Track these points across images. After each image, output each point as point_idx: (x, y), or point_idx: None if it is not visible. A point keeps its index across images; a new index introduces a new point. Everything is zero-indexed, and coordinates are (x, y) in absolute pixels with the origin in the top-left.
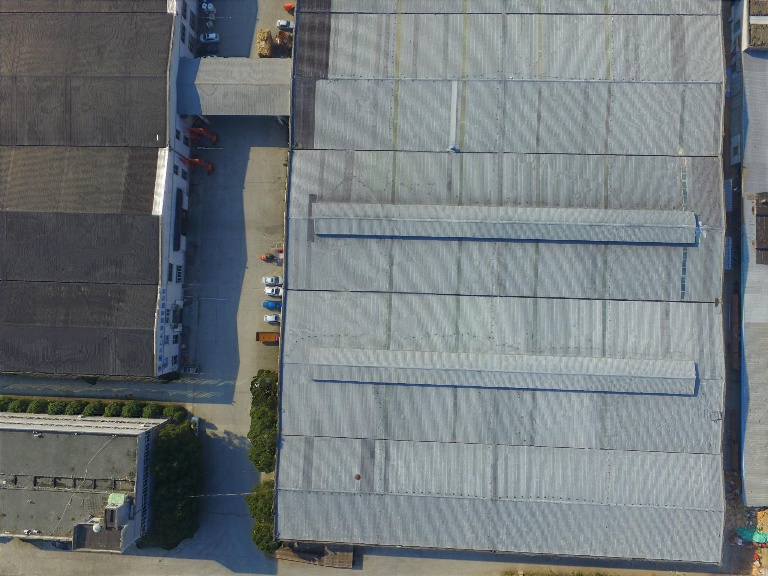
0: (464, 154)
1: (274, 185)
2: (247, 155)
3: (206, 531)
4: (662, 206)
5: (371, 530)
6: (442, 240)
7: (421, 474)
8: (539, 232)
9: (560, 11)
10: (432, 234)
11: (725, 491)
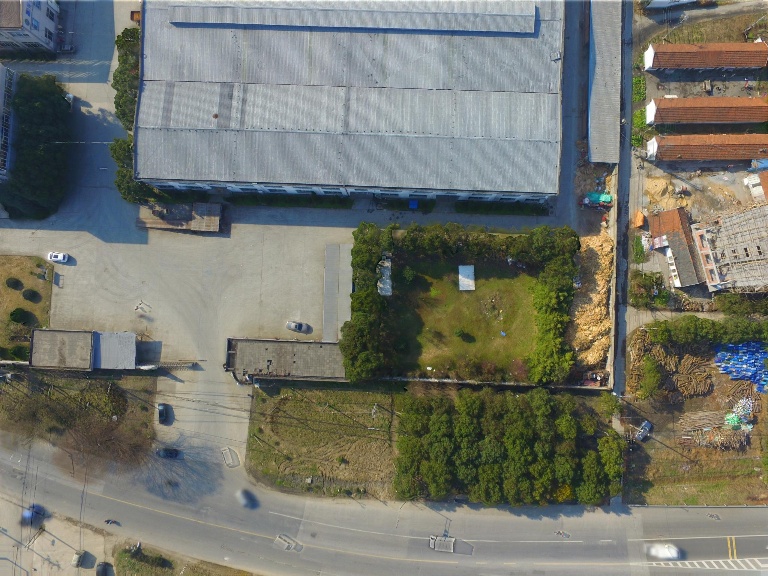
0: None
1: None
2: None
3: (79, 204)
4: None
5: (227, 167)
6: None
7: (276, 113)
8: None
9: None
10: None
11: (576, 160)
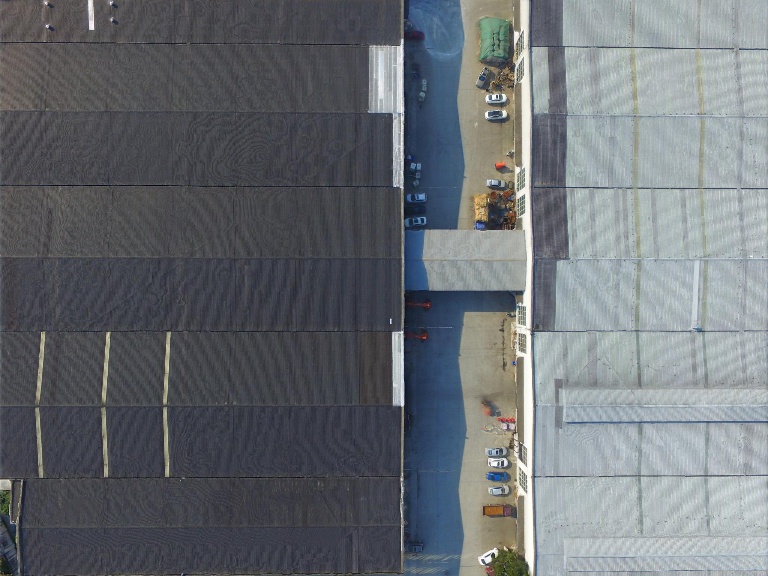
0: (706, 333)
1: (490, 351)
2: (461, 320)
3: None
4: None
5: None
6: (690, 423)
7: None
8: None
9: None
10: (683, 419)
11: None
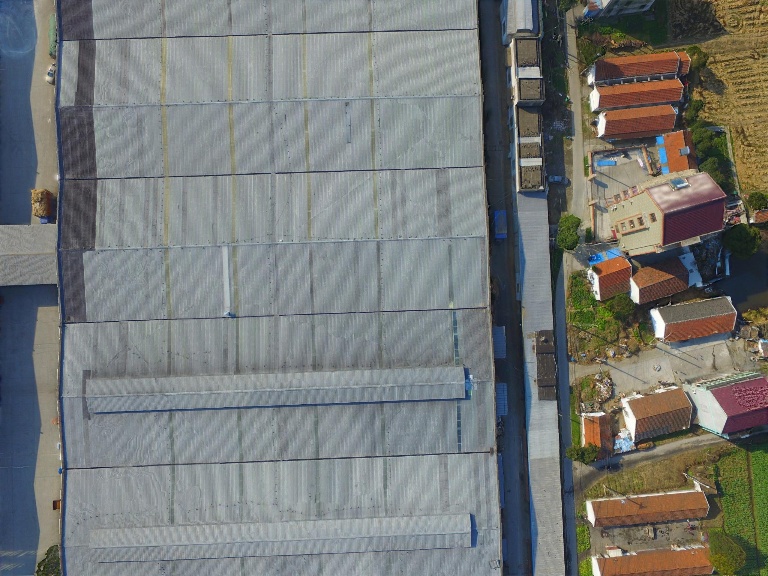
0: (240, 319)
1: None
2: (35, 316)
3: None
4: (435, 361)
5: None
6: (220, 409)
7: None
8: (314, 397)
9: (328, 169)
10: (208, 406)
11: None
